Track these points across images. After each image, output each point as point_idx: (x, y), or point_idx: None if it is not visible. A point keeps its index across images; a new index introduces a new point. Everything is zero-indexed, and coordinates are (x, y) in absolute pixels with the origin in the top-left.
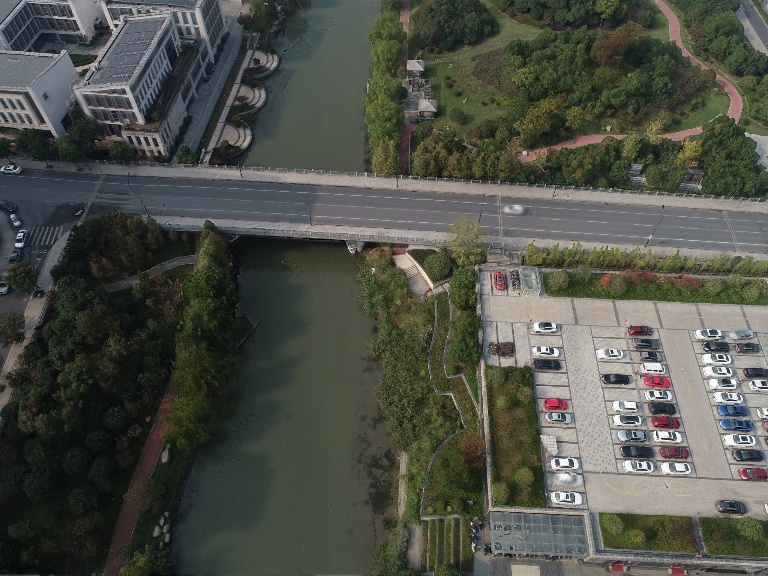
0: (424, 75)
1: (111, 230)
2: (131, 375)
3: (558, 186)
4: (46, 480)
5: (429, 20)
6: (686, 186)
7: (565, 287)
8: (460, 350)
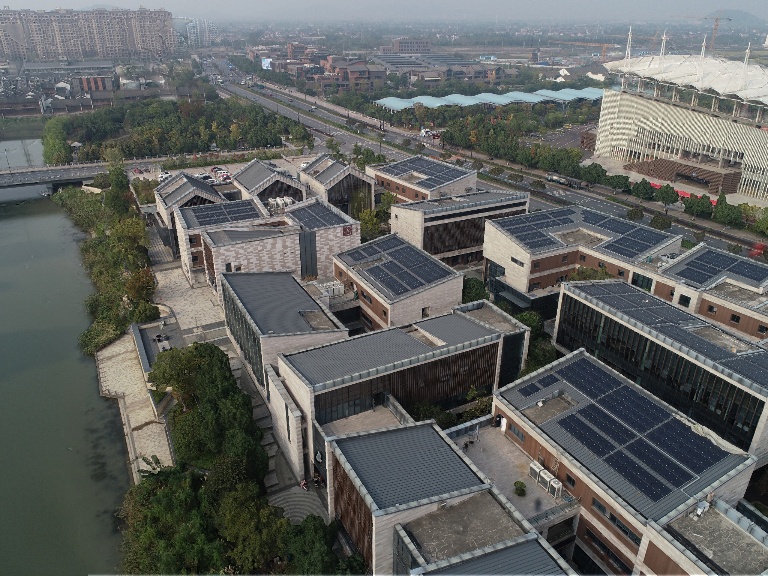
0: None
1: None
2: None
3: (170, 155)
4: None
5: (81, 129)
6: None
7: (173, 164)
8: (115, 181)
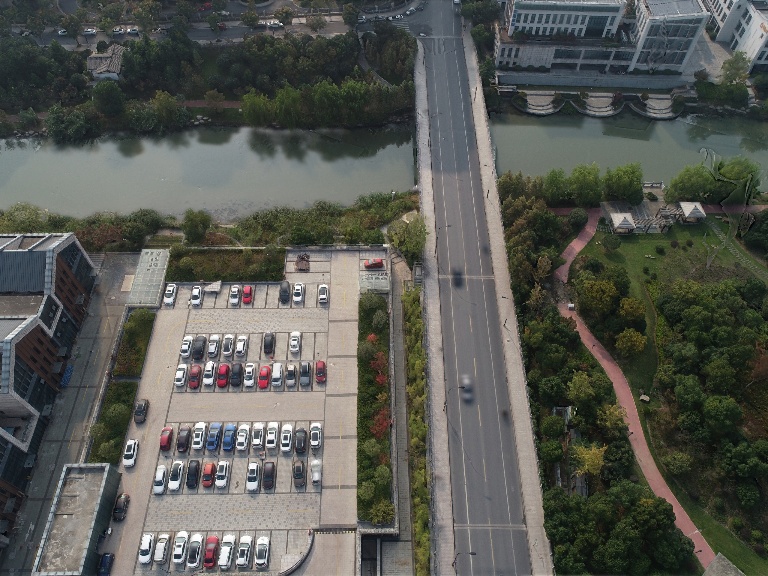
0: (689, 225)
1: (394, 40)
2: (296, 85)
3: None
4: (224, 61)
5: None
6: None
7: None
8: (295, 228)
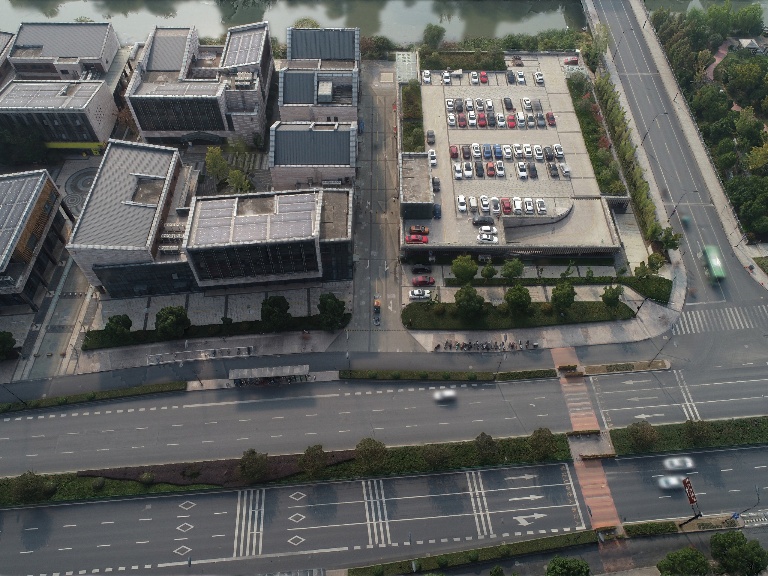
0: None
1: None
2: None
3: None
4: None
5: None
6: None
7: (574, 82)
8: (509, 38)
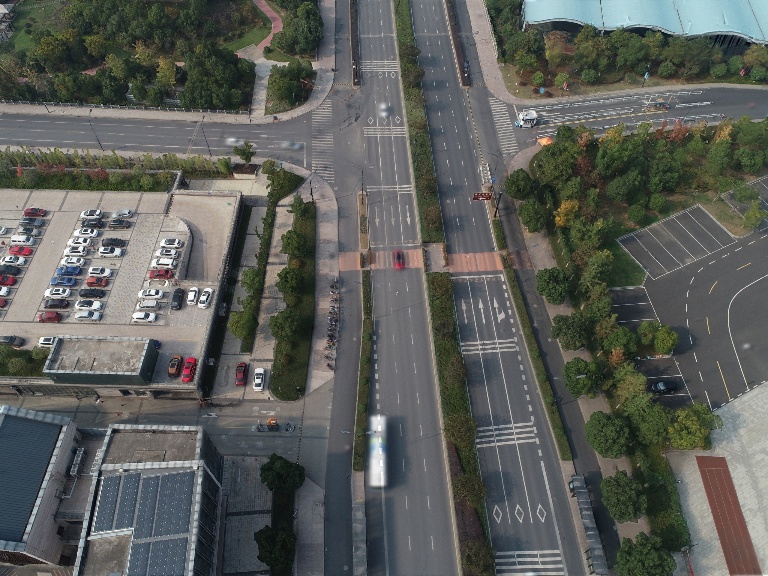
0: (16, 18)
1: None
2: None
3: (56, 103)
4: None
5: None
6: (176, 102)
7: None
8: None
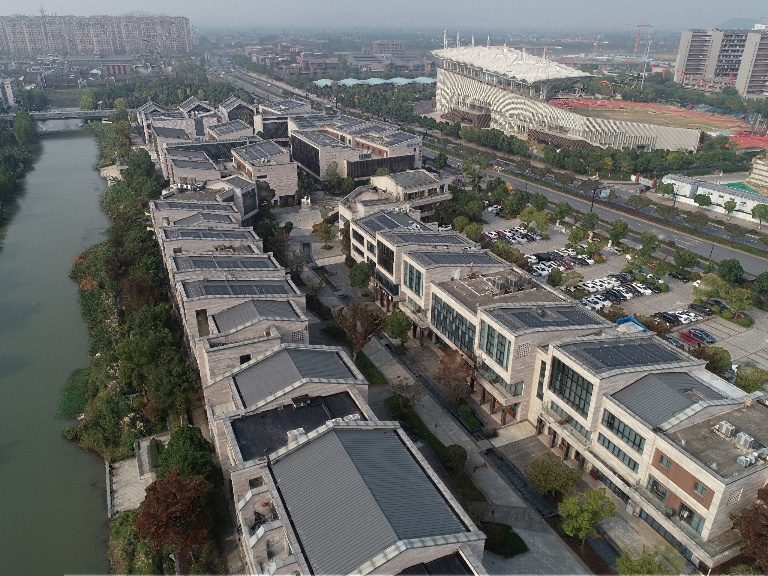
0: None
1: None
2: None
3: None
4: None
5: None
6: None
7: None
8: None
